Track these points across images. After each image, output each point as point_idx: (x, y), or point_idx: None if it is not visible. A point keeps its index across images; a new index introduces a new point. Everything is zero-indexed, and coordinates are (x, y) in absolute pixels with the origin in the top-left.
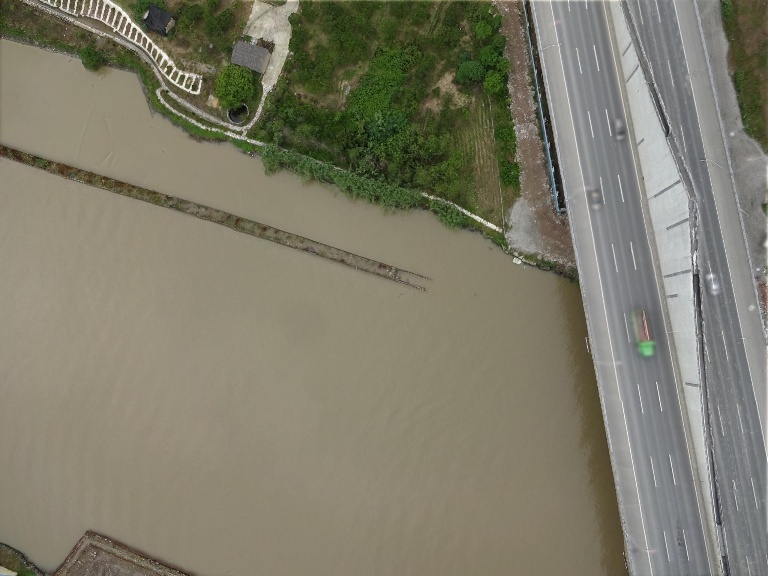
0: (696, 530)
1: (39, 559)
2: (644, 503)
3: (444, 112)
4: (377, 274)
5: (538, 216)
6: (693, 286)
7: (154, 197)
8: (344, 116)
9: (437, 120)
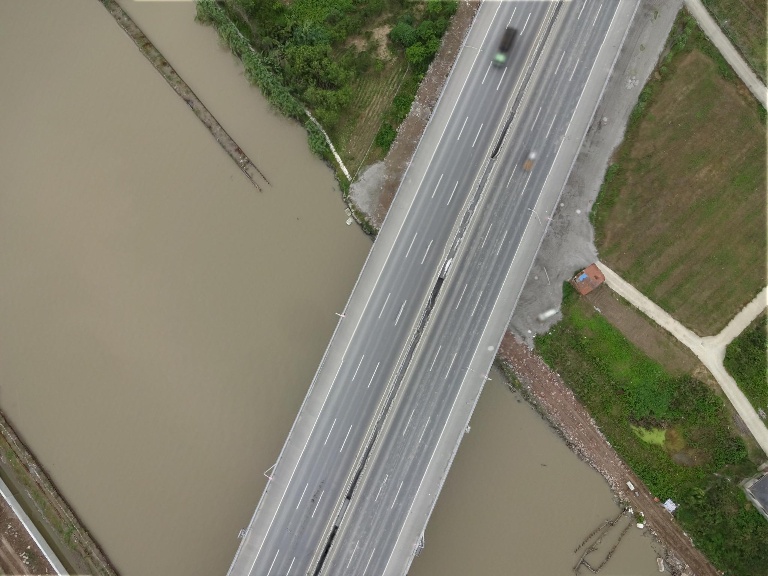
0: (333, 497)
1: None
2: (307, 451)
3: (362, 53)
4: (230, 155)
5: (386, 185)
6: (435, 286)
7: None
8: (284, 10)
9: (355, 58)
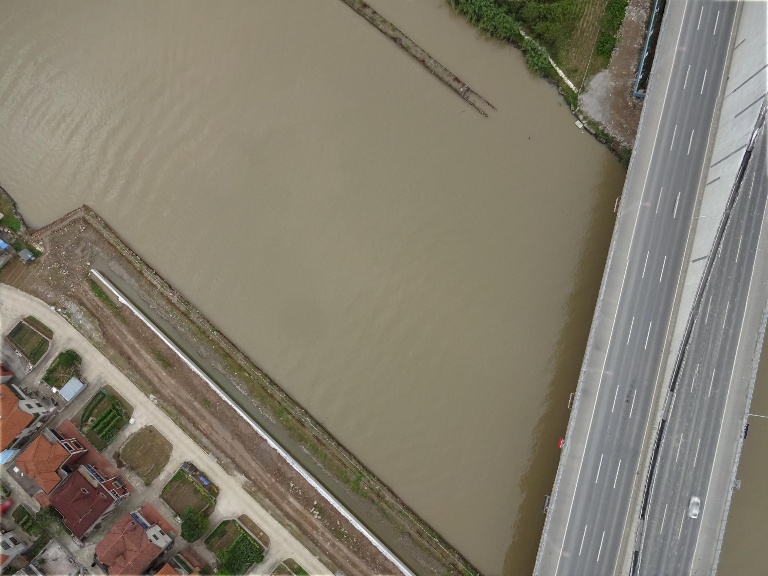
0: (647, 394)
1: (28, 214)
2: (611, 354)
3: None
4: (449, 85)
5: (615, 91)
6: (743, 160)
7: None
8: None
9: None
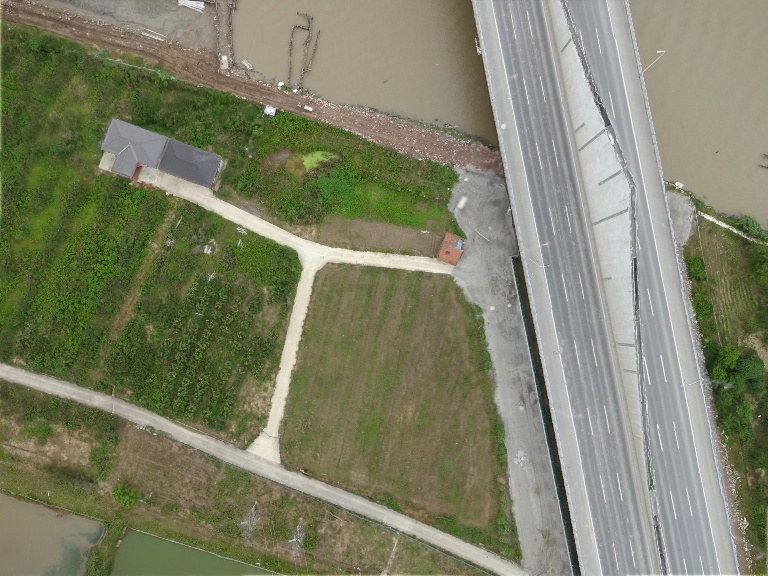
0: None
1: None
2: None
3: None
4: None
5: None
6: None
7: None
8: None
9: None
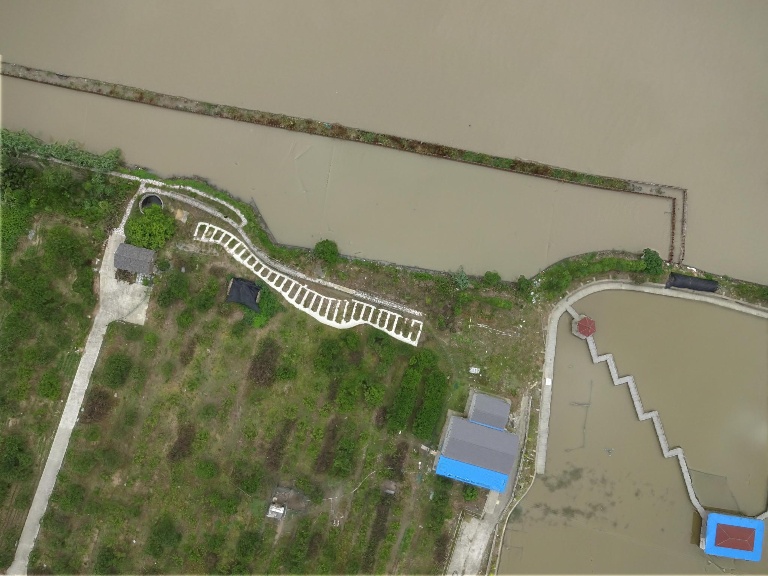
0: None
1: None
2: None
3: None
4: None
5: None
6: None
7: (234, 113)
8: None
9: None
